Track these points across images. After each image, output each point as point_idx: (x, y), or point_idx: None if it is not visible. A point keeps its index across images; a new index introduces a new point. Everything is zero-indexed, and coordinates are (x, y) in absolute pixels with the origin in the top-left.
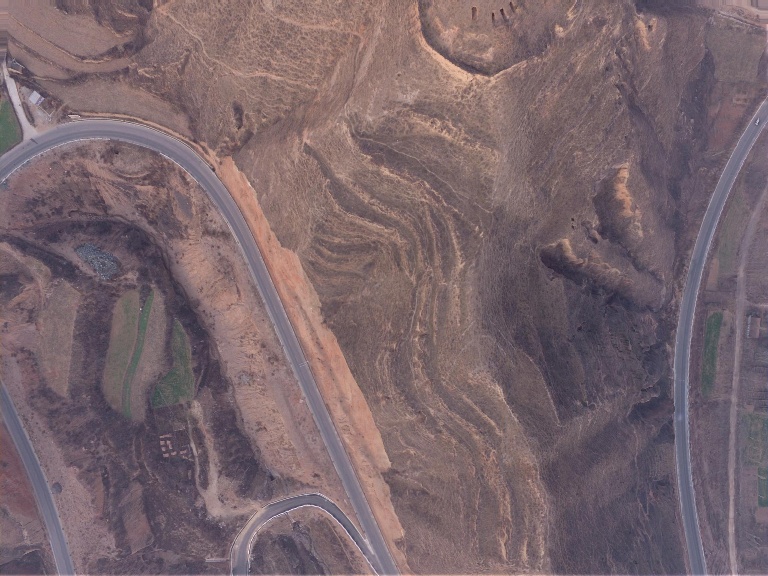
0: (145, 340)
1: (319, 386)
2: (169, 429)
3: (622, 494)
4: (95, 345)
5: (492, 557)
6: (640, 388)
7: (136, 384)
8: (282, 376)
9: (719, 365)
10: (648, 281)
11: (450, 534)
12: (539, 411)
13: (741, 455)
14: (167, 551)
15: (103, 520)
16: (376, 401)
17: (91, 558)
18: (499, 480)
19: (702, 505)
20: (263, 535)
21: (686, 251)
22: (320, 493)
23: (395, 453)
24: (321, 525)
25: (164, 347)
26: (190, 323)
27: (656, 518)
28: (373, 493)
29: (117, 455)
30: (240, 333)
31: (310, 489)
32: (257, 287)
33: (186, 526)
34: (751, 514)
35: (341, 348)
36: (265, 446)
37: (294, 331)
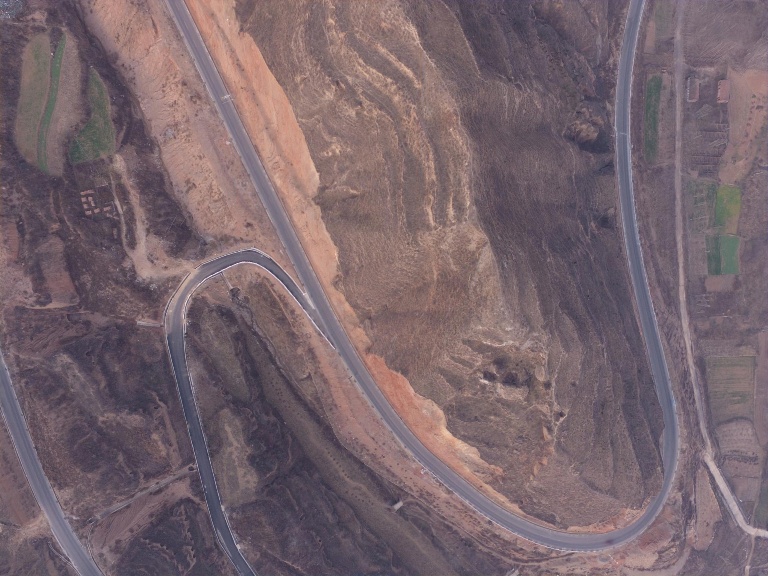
0: (59, 88)
1: (246, 126)
2: (90, 185)
3: (560, 204)
4: (3, 90)
5: (420, 229)
6: (574, 107)
7: (52, 136)
8: (206, 116)
9: (661, 130)
10: (579, 12)
11: (379, 225)
12: (458, 62)
13: (688, 222)
14: (94, 313)
15: (18, 264)
16: (295, 88)
17: (7, 304)
18: (421, 139)
19: (651, 266)
20: (198, 299)
21: (621, 10)
22: (255, 248)
23: (321, 158)
24: (259, 288)
25: (80, 95)
26: (108, 75)
27: (599, 246)
28: (309, 237)
29: (33, 204)
30: (161, 81)
31: (244, 244)
32: (174, 19)
33: (113, 285)
34: (701, 282)
35: (257, 44)
36: (196, 208)
37: (216, 67)
